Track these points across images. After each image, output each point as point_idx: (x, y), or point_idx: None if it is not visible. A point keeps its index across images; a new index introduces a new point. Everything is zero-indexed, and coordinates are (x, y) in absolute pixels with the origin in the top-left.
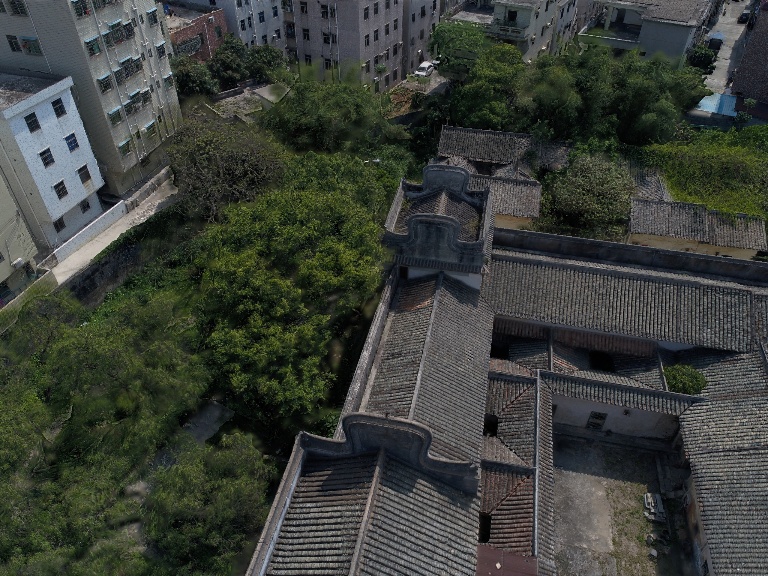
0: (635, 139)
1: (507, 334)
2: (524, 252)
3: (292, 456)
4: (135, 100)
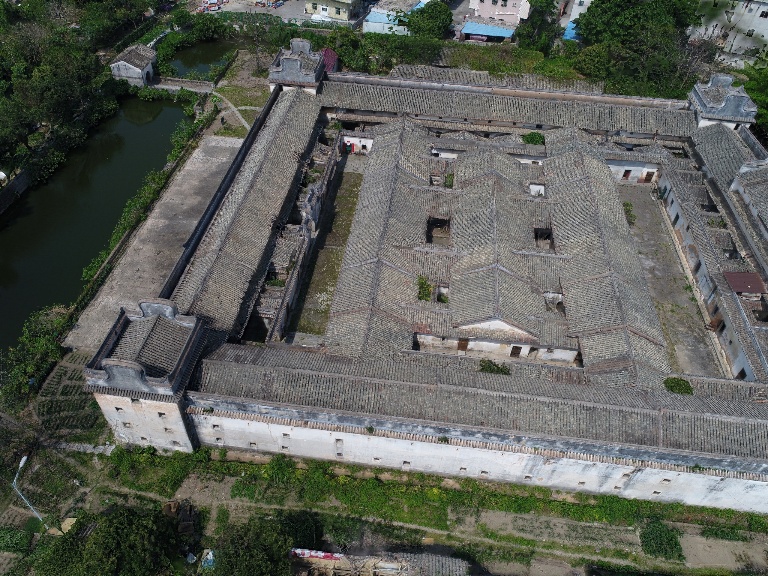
0: None
1: None
2: None
3: None
4: None
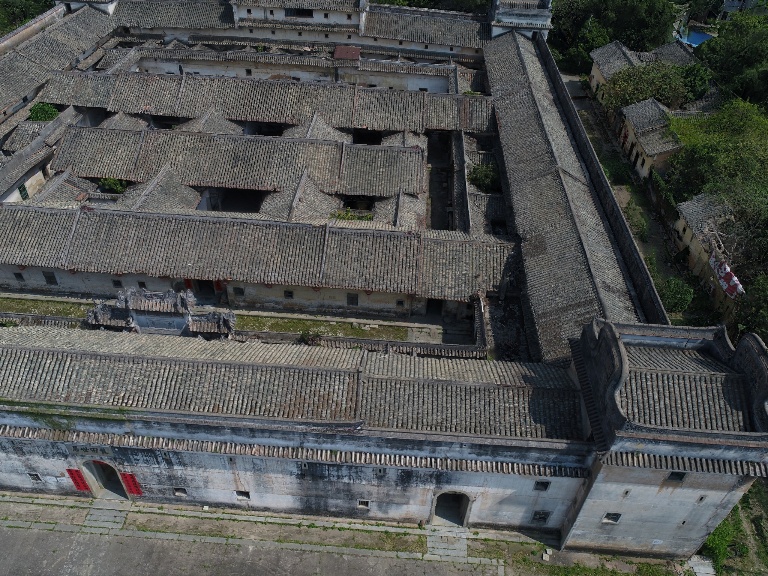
0: (754, 101)
1: None
2: None
3: None
4: None
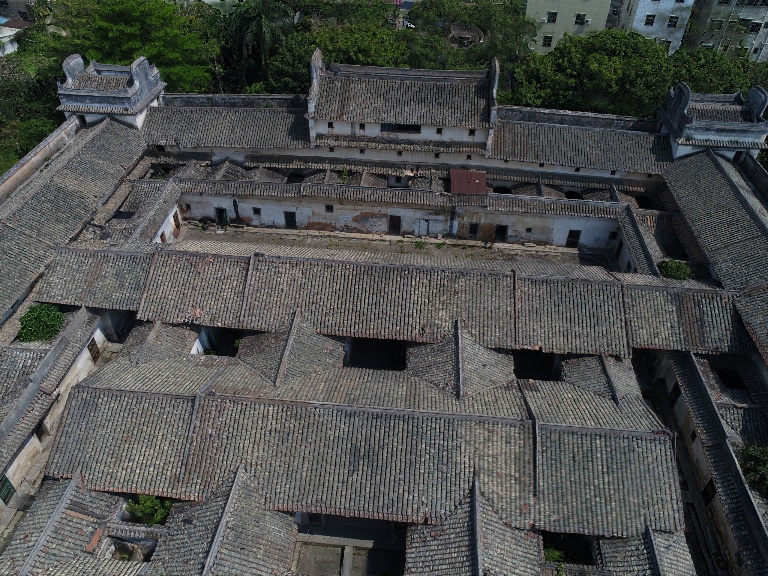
0: None
1: (660, 198)
2: (746, 180)
3: None
4: (742, 23)
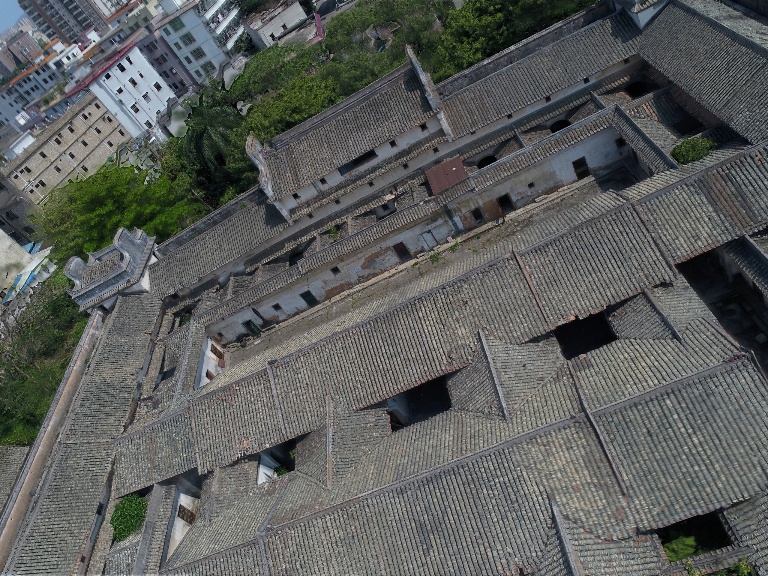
0: None
1: (649, 78)
2: (731, 6)
3: (403, 64)
4: None
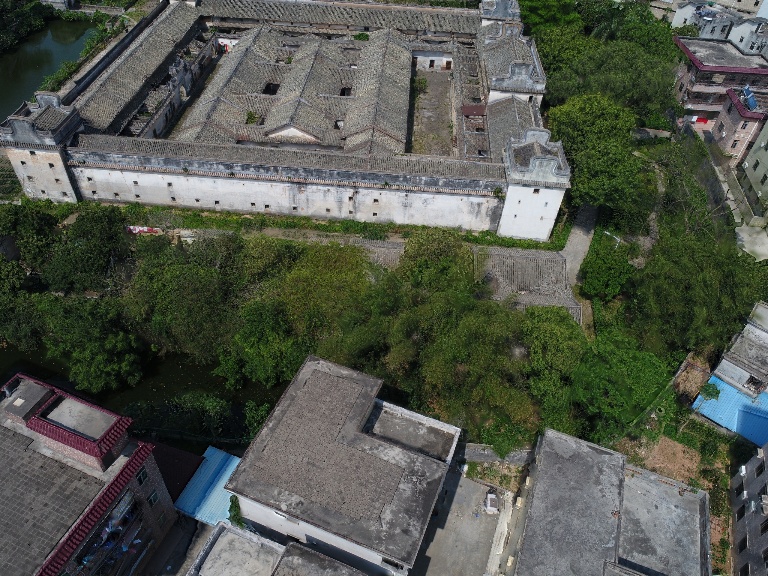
0: None
1: None
2: None
3: None
4: None
